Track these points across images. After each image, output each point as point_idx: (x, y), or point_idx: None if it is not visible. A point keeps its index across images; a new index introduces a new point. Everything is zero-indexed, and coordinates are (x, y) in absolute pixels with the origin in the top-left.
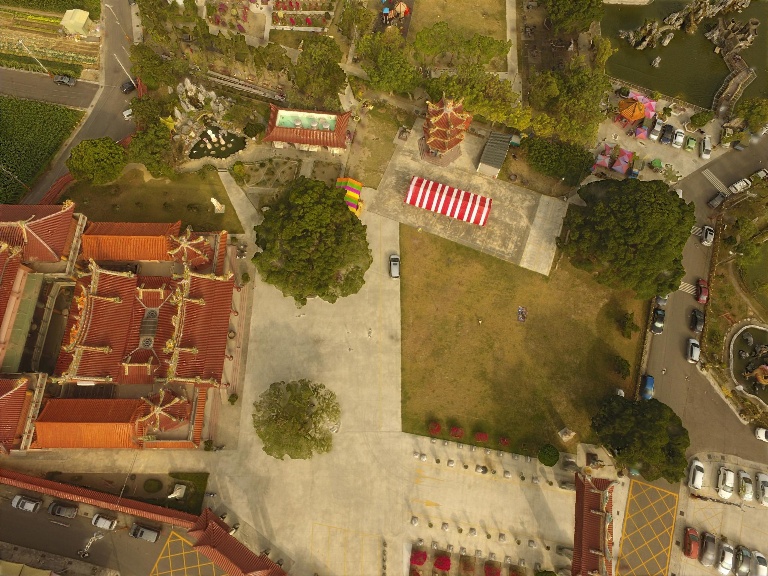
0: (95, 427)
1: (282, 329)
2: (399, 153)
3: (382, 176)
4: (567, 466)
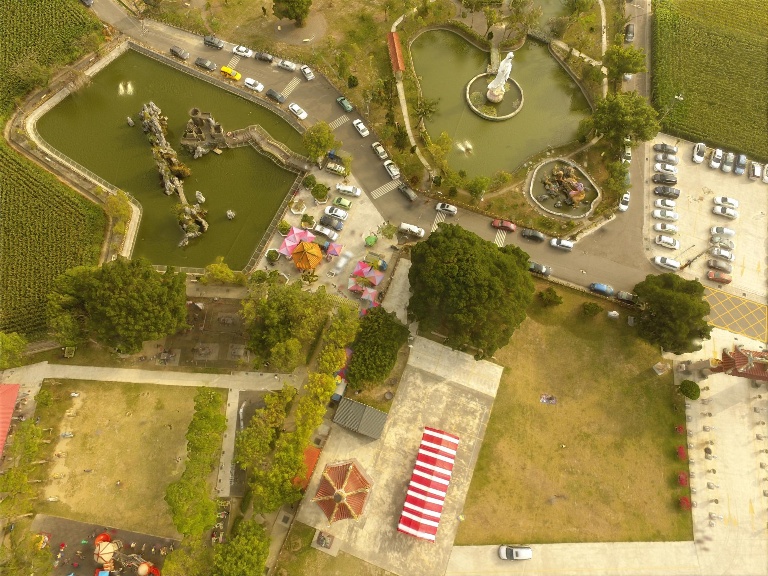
0: None
1: None
2: (353, 547)
3: (388, 572)
4: (690, 372)
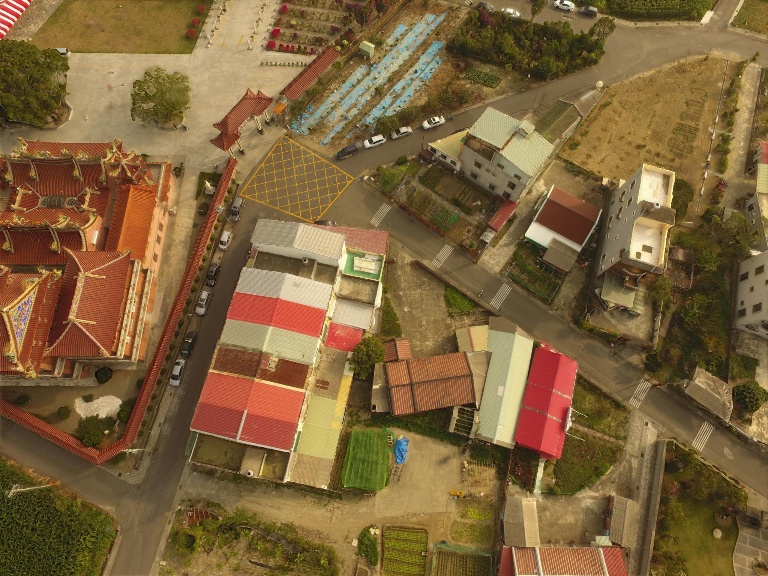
0: (131, 214)
1: (94, 131)
2: None
3: None
4: None
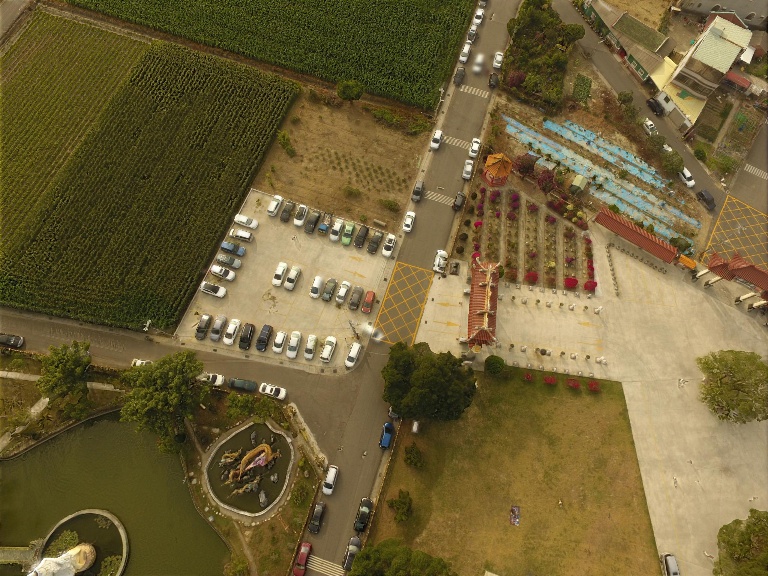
0: None
1: (767, 482)
2: None
3: None
4: (474, 357)
